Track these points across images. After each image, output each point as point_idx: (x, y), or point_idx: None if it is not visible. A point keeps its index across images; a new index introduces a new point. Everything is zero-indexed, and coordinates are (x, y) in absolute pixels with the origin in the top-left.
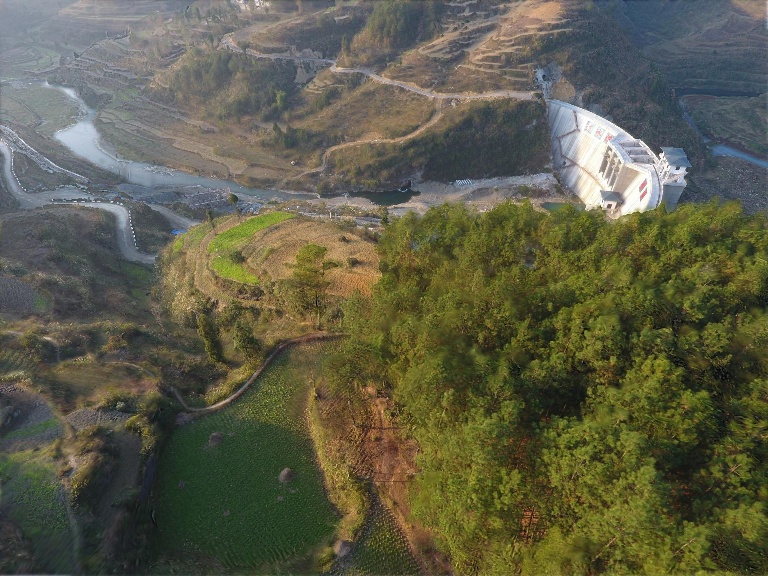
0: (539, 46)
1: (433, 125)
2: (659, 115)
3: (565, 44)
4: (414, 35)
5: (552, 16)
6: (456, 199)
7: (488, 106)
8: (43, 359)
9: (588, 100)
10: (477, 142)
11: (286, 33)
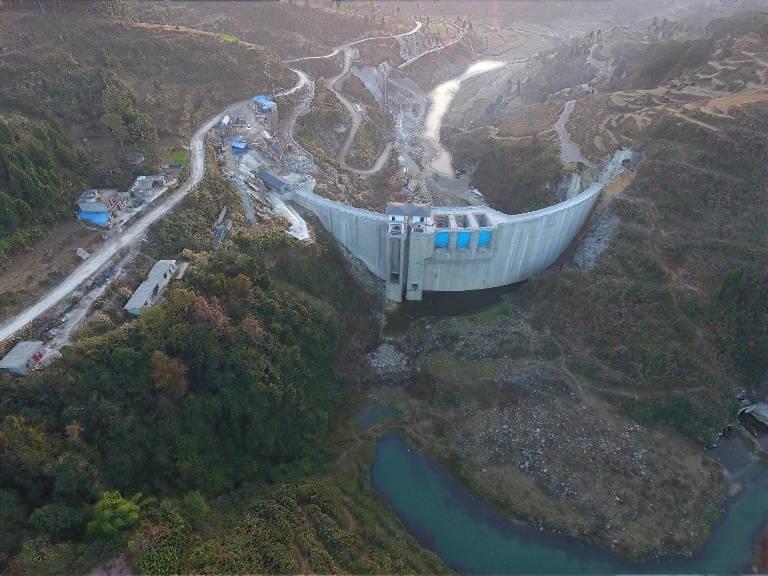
0: (655, 126)
1: (514, 139)
2: (663, 295)
3: (684, 141)
4: (659, 82)
5: (720, 104)
6: (450, 193)
7: (545, 148)
8: (136, 8)
9: (614, 207)
10: (510, 170)
11: (621, 47)
